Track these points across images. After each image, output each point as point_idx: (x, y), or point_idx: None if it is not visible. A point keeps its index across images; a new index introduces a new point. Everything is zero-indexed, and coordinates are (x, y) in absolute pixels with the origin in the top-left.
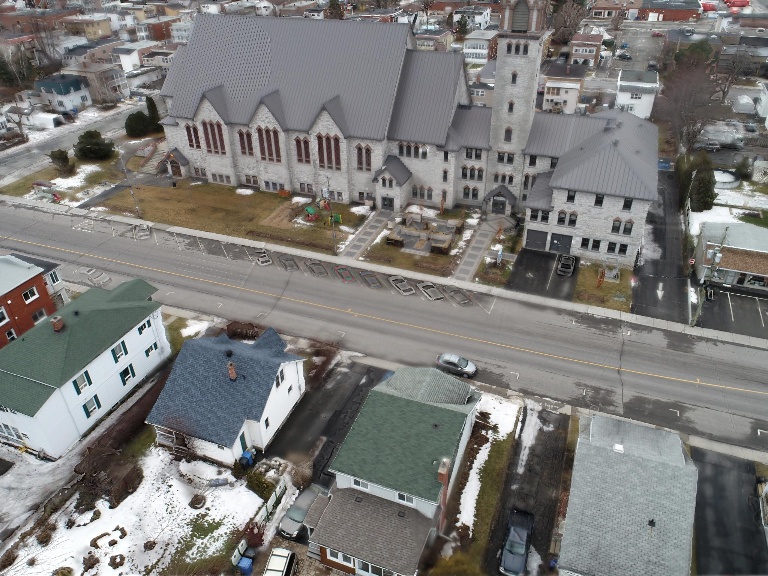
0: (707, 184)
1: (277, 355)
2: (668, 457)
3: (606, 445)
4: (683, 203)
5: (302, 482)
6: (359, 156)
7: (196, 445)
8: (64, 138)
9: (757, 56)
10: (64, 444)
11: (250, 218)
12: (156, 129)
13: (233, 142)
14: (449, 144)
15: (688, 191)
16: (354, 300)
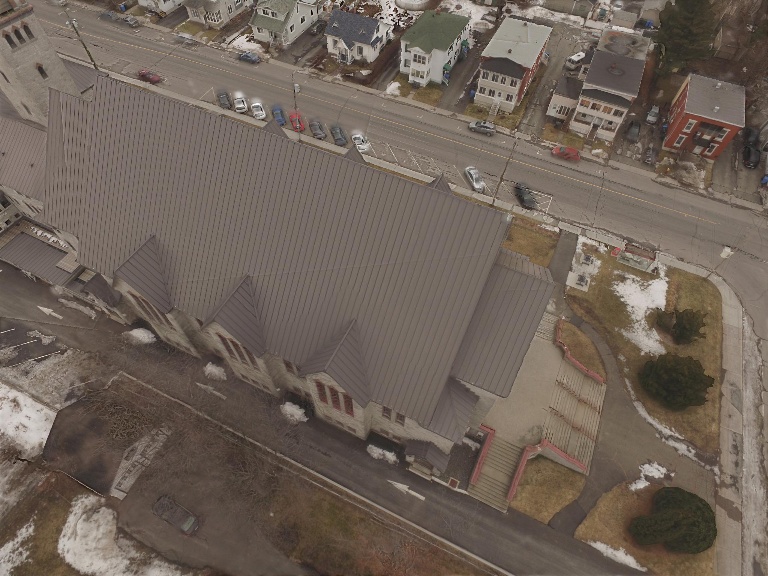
0: None
1: None
2: None
3: None
4: None
5: None
6: None
7: None
8: None
9: None
10: None
11: None
12: None
13: None
14: None
15: None
16: None
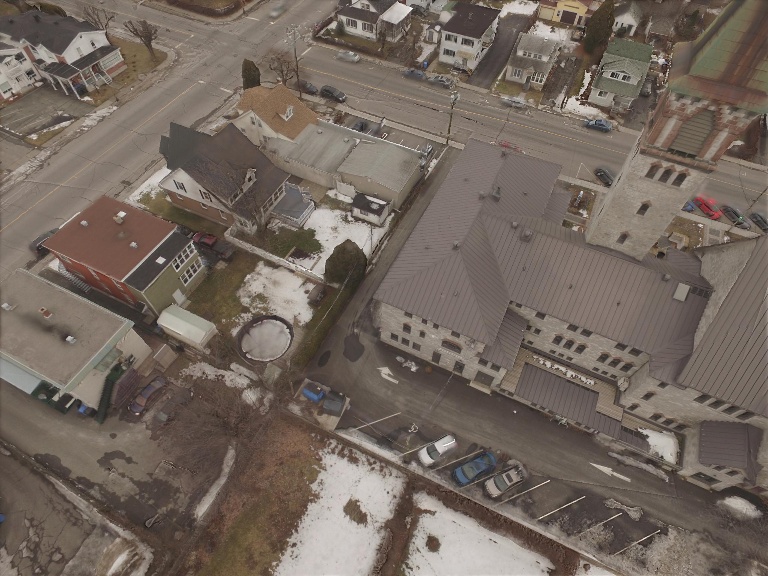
0: None
1: None
2: (528, 37)
3: (551, 40)
4: None
5: None
6: None
7: None
8: None
9: None
10: None
11: None
12: None
13: None
14: None
15: None
16: None
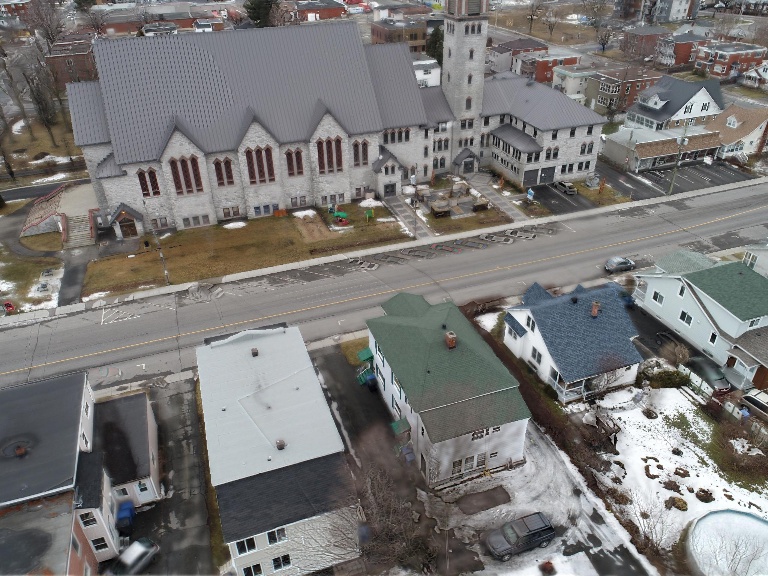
0: None
1: None
2: None
3: None
4: None
5: (688, 360)
6: (355, 153)
7: (619, 375)
8: None
9: None
10: None
11: (289, 242)
12: None
13: (208, 175)
14: (428, 122)
15: None
16: (489, 260)
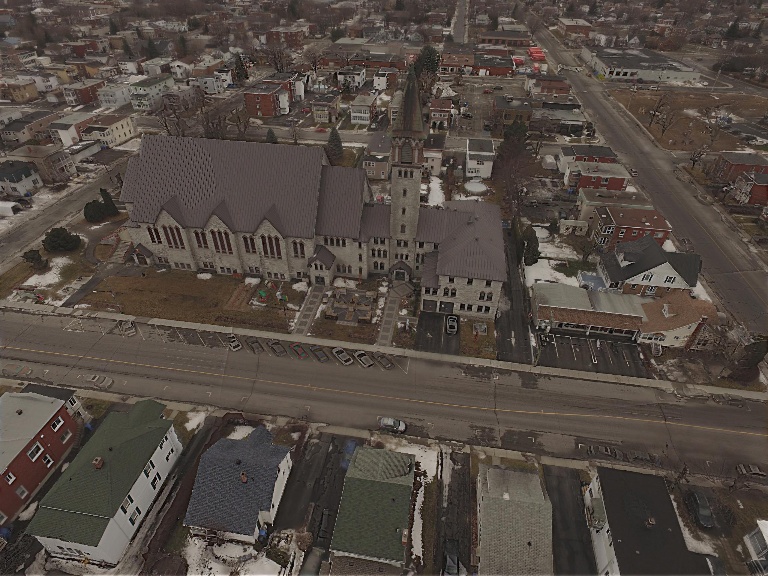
0: (534, 247)
1: (272, 454)
2: (534, 497)
3: (499, 495)
4: (520, 260)
5: (306, 548)
6: (295, 248)
7: (226, 537)
8: (27, 227)
9: (555, 119)
10: (119, 551)
11: (215, 304)
12: (112, 213)
13: (190, 239)
14: (362, 237)
15: (522, 253)
16: (311, 375)
